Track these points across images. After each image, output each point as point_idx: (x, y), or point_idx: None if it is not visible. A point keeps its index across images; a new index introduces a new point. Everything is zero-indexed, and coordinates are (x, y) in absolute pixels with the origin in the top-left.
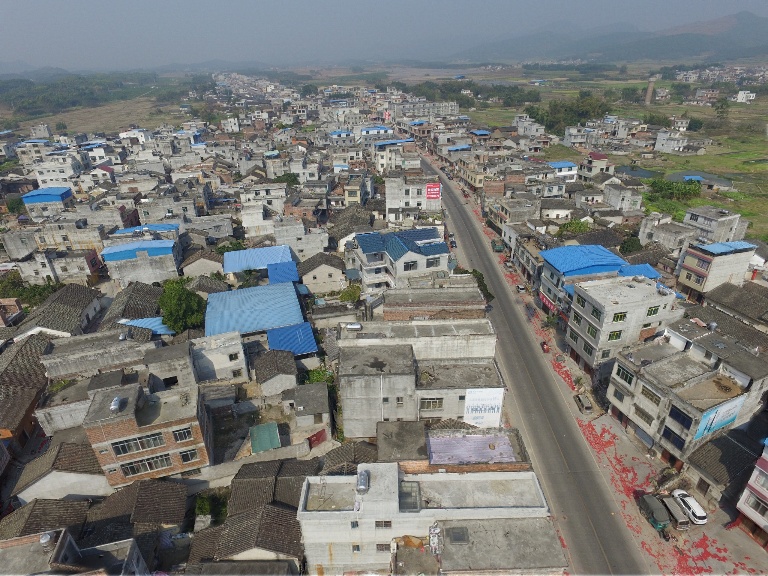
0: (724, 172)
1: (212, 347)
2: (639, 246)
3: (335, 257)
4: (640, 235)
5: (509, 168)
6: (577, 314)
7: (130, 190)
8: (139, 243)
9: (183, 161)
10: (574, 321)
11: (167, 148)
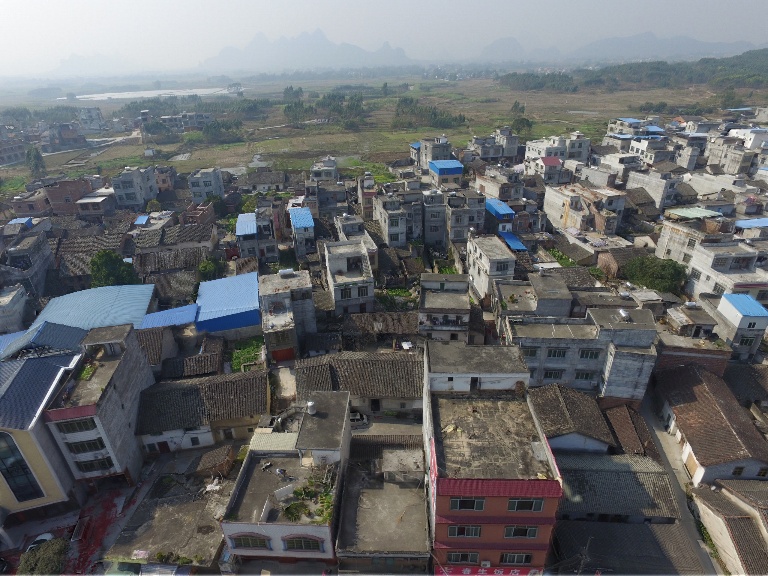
0: None
1: (2, 298)
2: None
3: (161, 350)
4: None
5: None
6: None
7: (481, 187)
8: (249, 220)
9: (642, 181)
10: None
11: (735, 163)
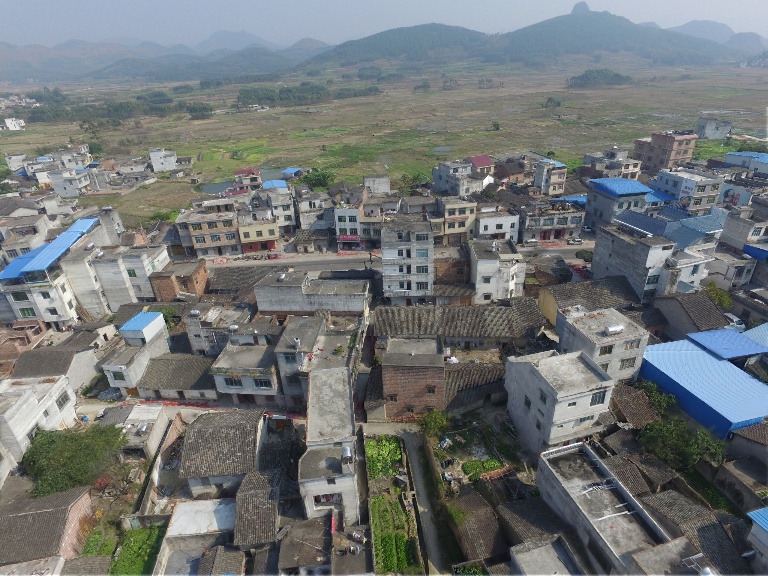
0: (257, 166)
1: None
2: (493, 194)
3: (658, 297)
4: (461, 193)
5: (346, 188)
6: (698, 199)
7: None
8: None
9: None
10: (694, 205)
11: None
